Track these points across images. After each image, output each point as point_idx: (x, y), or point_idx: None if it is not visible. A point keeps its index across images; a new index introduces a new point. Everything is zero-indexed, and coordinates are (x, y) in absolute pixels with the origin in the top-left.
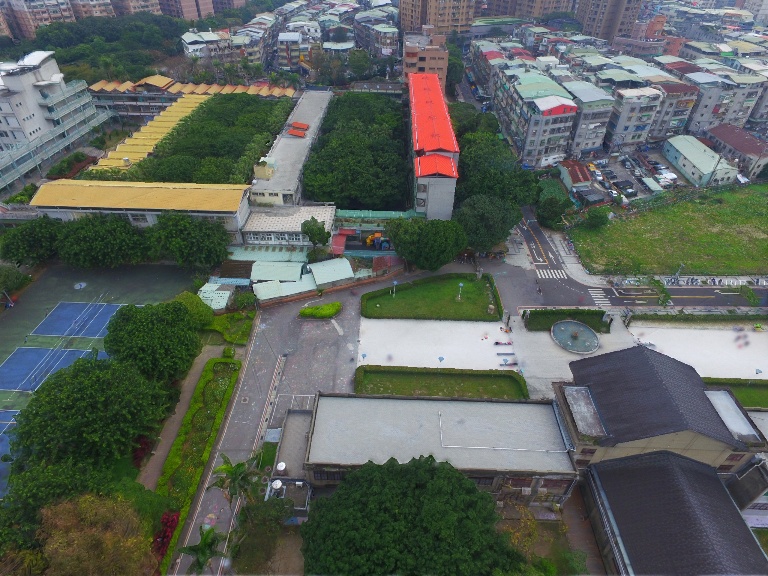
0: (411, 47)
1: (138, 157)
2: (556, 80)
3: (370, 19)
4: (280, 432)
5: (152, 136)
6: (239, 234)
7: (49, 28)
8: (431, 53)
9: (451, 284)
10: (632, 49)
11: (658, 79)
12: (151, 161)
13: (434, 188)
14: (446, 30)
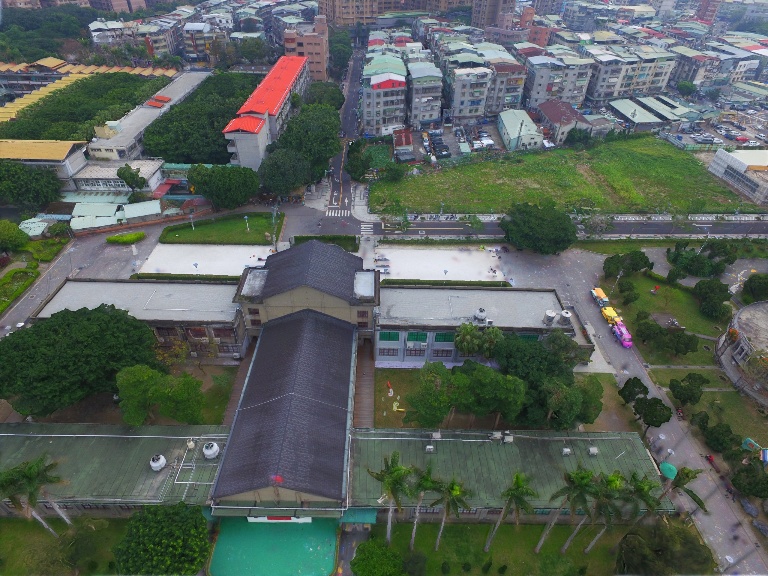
0: (288, 33)
1: None
2: (406, 61)
3: (282, 12)
4: None
5: (22, 106)
6: (71, 181)
7: None
8: (308, 39)
9: (248, 220)
10: (499, 37)
11: (496, 61)
12: (8, 124)
13: (241, 143)
14: (352, 22)
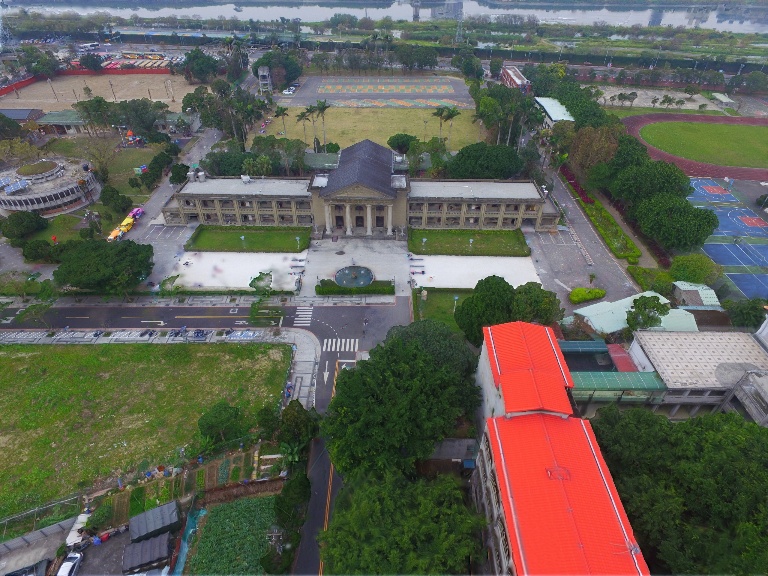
0: None
1: None
2: None
3: None
4: (560, 228)
5: None
6: None
7: None
8: None
9: None
10: None
11: None
12: None
13: None
14: None
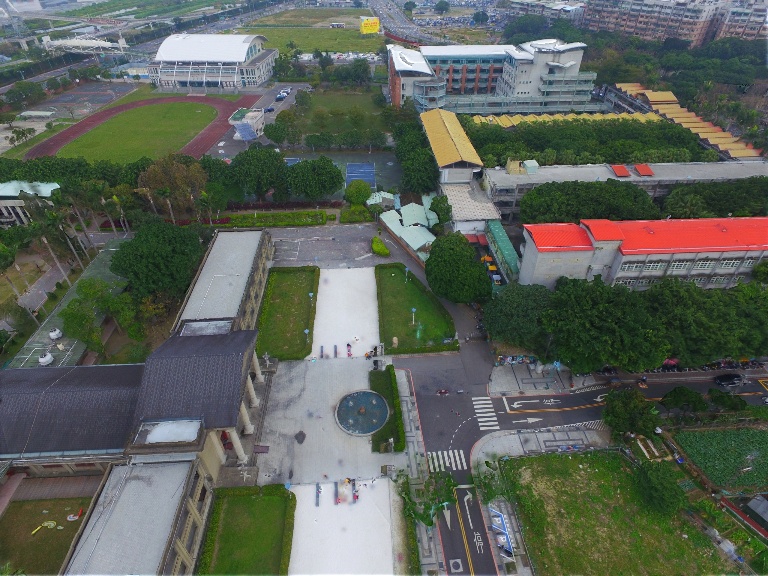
0: None
1: (506, 124)
2: None
3: None
4: None
5: None
6: None
7: (720, 40)
8: None
9: (435, 318)
10: None
11: None
12: None
13: (528, 248)
14: None
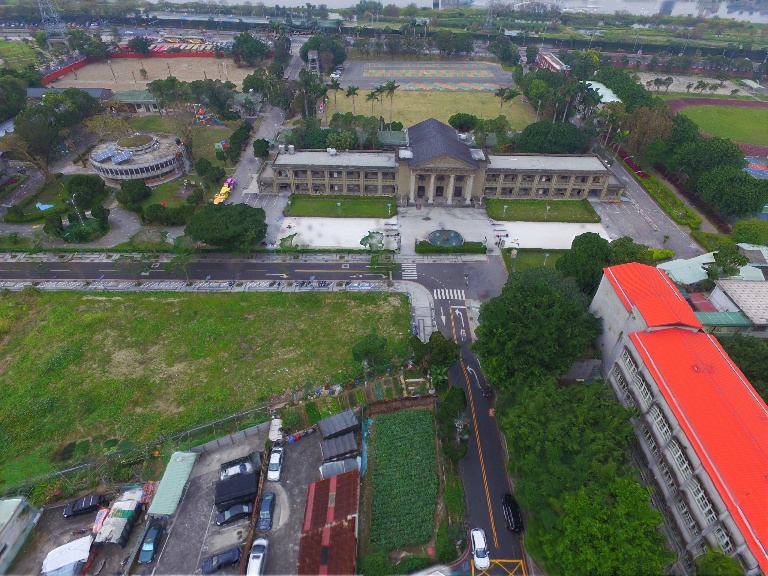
0: None
1: None
2: None
3: None
4: (622, 199)
5: None
6: None
7: None
8: None
9: None
10: None
11: None
12: None
13: None
14: None
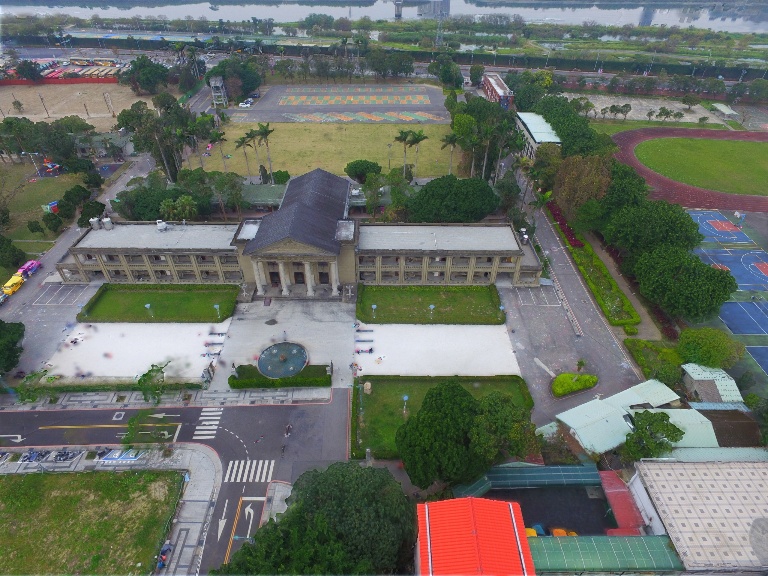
0: None
1: None
2: None
3: None
4: (543, 282)
5: None
6: None
7: None
8: None
9: None
10: None
11: None
12: None
13: None
14: None
